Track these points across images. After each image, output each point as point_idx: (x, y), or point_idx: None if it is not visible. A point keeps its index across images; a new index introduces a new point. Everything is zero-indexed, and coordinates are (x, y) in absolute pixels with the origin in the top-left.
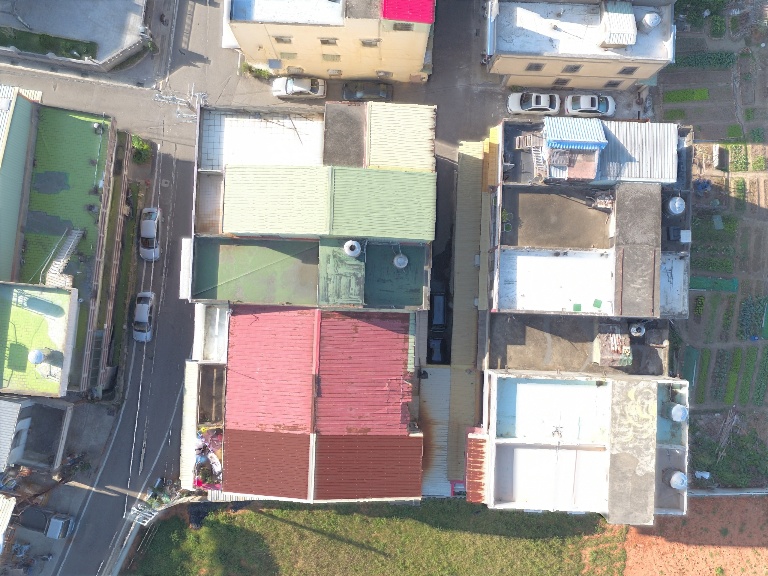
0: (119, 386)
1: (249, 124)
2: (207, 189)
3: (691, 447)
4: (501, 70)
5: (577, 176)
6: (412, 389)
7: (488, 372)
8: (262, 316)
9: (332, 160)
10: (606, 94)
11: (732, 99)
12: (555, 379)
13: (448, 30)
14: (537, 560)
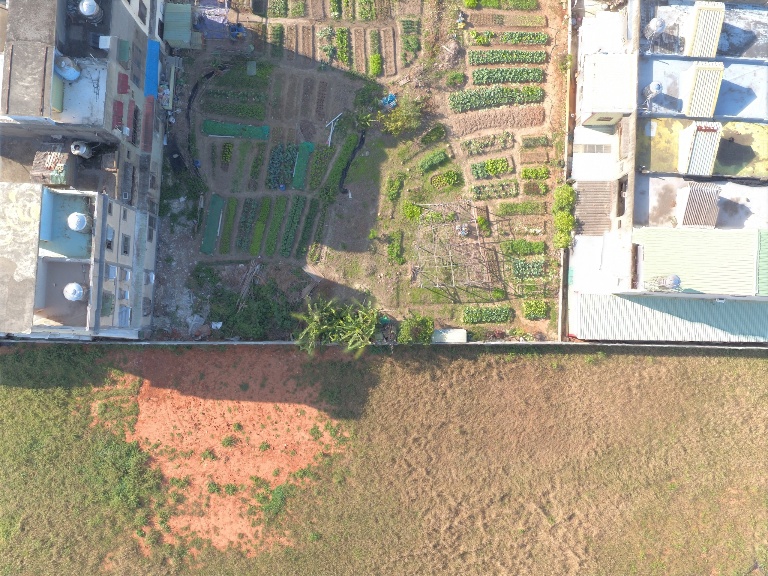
0: None
1: None
2: None
3: (210, 298)
4: None
5: None
6: None
7: None
8: None
9: None
10: None
11: None
12: None
13: None
14: (40, 411)
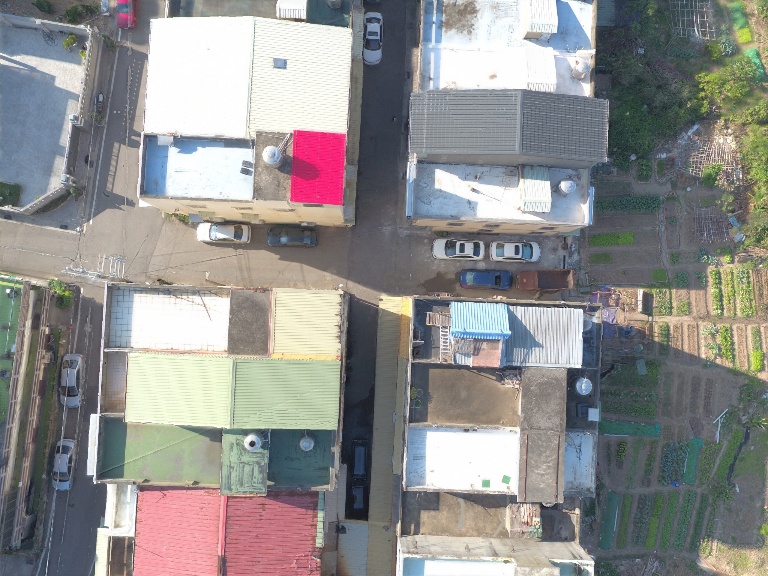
0: (38, 536)
1: (158, 300)
2: (115, 366)
3: None
4: (422, 224)
5: (481, 364)
6: (330, 544)
7: (399, 543)
8: (169, 493)
9: (236, 347)
10: (532, 238)
11: (657, 243)
12: (462, 558)
13: (374, 173)
14: None
